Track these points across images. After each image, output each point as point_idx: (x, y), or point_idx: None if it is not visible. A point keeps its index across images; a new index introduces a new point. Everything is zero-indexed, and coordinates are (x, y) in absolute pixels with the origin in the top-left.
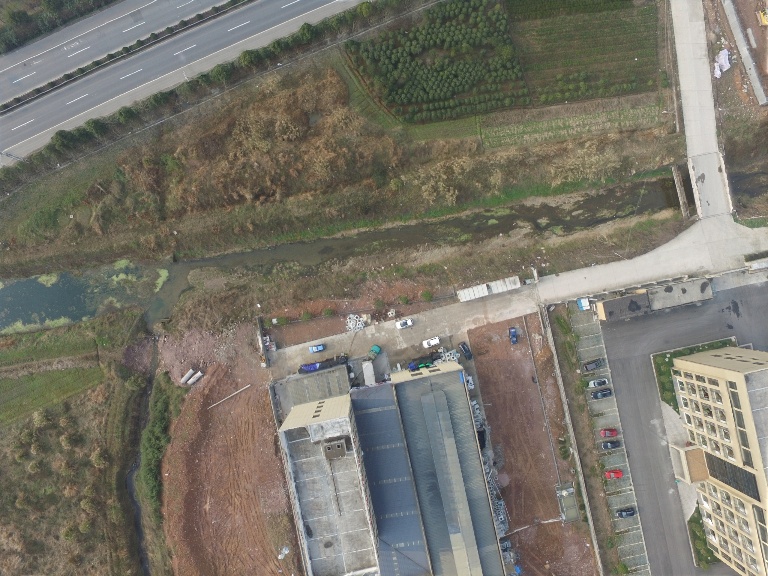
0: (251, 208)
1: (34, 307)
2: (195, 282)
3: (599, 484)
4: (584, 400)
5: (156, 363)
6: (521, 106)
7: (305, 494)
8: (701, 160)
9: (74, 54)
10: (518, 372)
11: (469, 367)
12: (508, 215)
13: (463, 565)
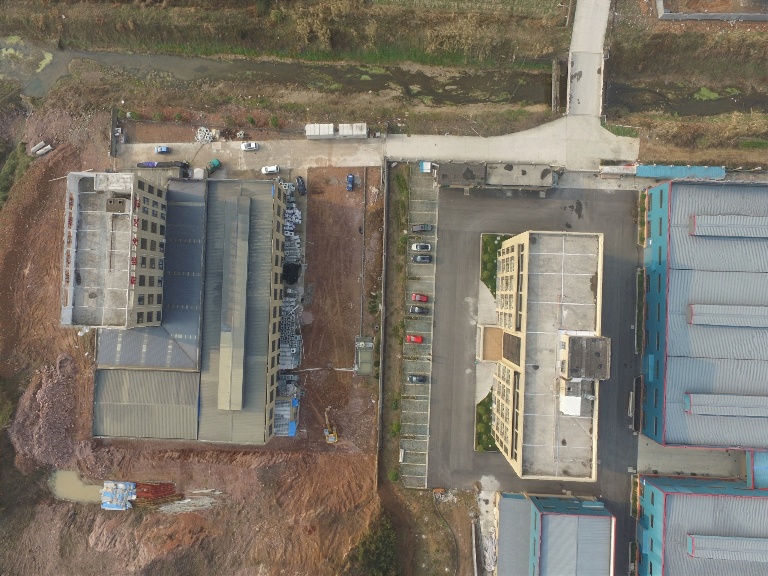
0: (135, 7)
1: None
2: (74, 71)
3: (398, 345)
4: (404, 261)
5: (20, 136)
6: None
7: (83, 244)
8: (582, 58)
9: None
10: (347, 219)
11: (301, 203)
12: (382, 75)
13: (226, 363)
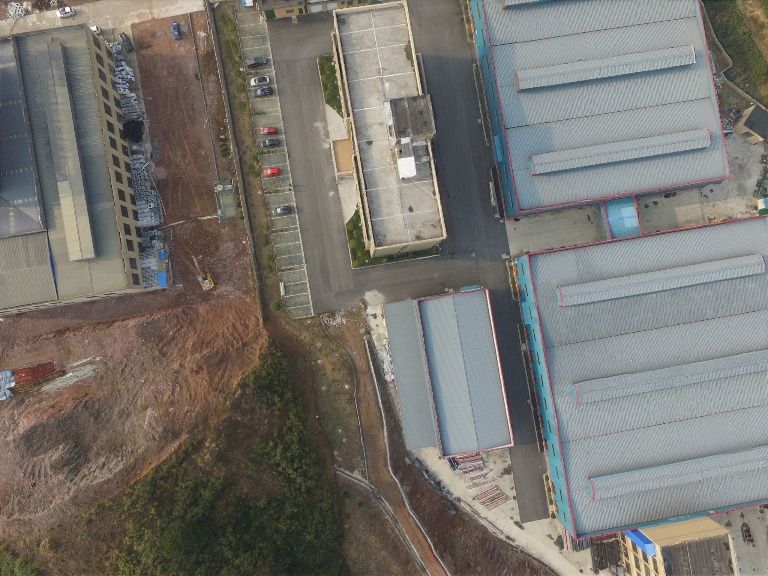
0: None
1: None
2: None
3: (257, 182)
4: (245, 98)
5: None
6: None
7: None
8: None
9: None
10: (181, 68)
11: (131, 60)
12: None
13: (69, 213)
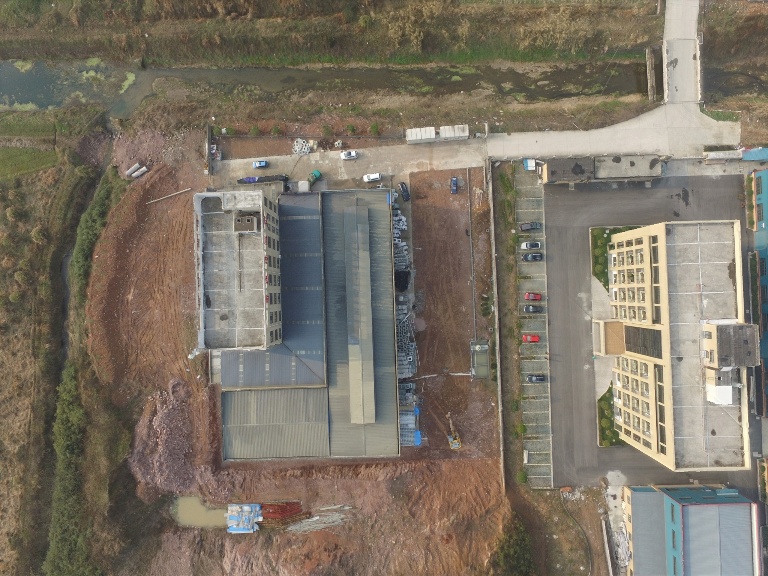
0: (221, 21)
1: (6, 89)
2: (159, 89)
3: (514, 346)
4: (514, 260)
5: (109, 159)
6: None
7: (210, 265)
8: (677, 45)
9: None
10: (453, 222)
11: (405, 209)
12: (473, 74)
13: (356, 376)
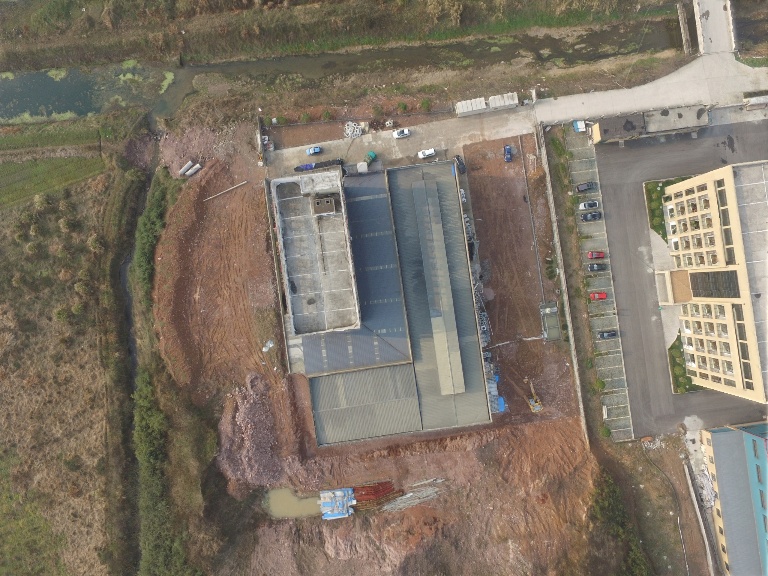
0: (259, 11)
1: (42, 100)
2: (199, 86)
3: (583, 305)
4: (574, 221)
5: (156, 161)
6: None
7: (292, 251)
8: None
9: None
10: (510, 190)
11: (462, 181)
12: (511, 44)
13: (442, 348)
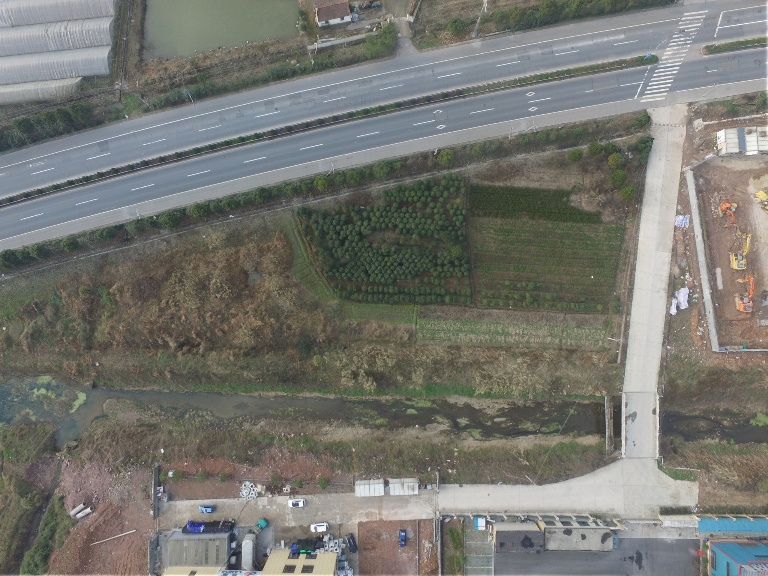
0: (172, 357)
1: None
2: (109, 411)
3: None
4: None
5: (57, 482)
6: (463, 303)
7: None
8: (636, 398)
9: (37, 173)
10: (401, 575)
11: (352, 559)
12: (428, 408)
13: None
